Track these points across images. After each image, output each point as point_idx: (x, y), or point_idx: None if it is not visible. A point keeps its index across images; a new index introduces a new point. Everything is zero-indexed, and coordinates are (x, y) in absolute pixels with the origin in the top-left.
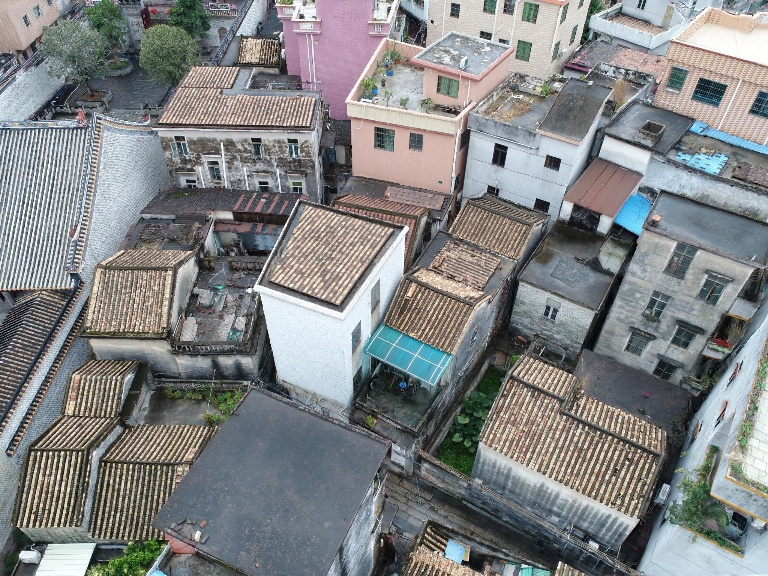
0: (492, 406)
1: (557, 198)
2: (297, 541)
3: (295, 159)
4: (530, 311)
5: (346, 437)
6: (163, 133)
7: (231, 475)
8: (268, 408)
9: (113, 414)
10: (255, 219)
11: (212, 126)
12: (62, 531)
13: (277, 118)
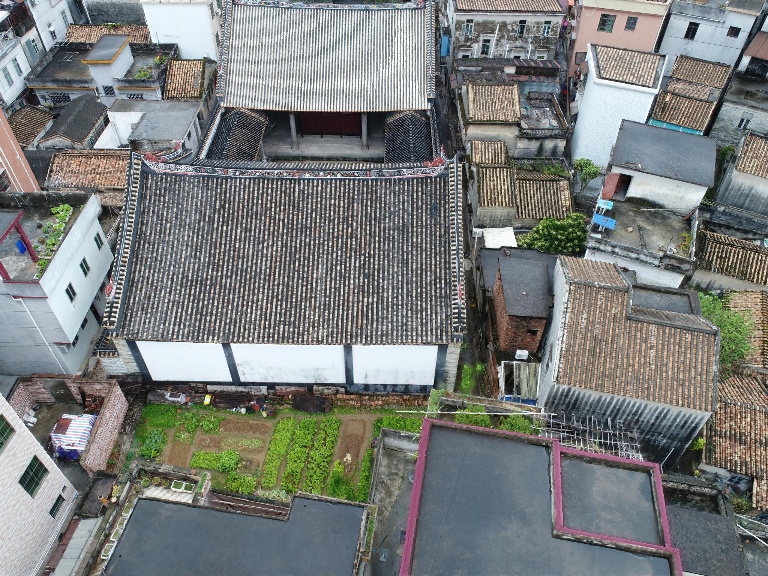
0: (741, 150)
1: (732, 59)
2: (691, 169)
3: (545, 37)
4: (727, 126)
5: (691, 137)
6: (460, 17)
7: (639, 149)
8: (639, 127)
9: (503, 162)
10: (530, 72)
11: (496, 11)
12: (500, 214)
13: (537, 7)
